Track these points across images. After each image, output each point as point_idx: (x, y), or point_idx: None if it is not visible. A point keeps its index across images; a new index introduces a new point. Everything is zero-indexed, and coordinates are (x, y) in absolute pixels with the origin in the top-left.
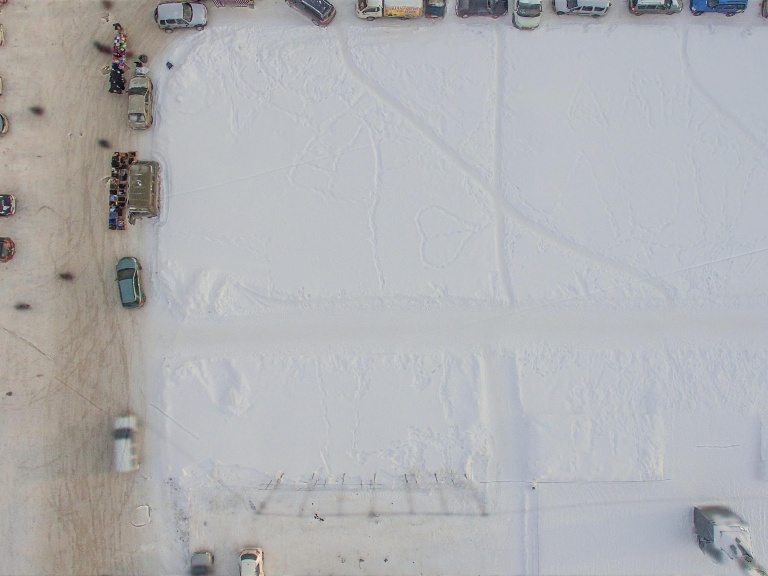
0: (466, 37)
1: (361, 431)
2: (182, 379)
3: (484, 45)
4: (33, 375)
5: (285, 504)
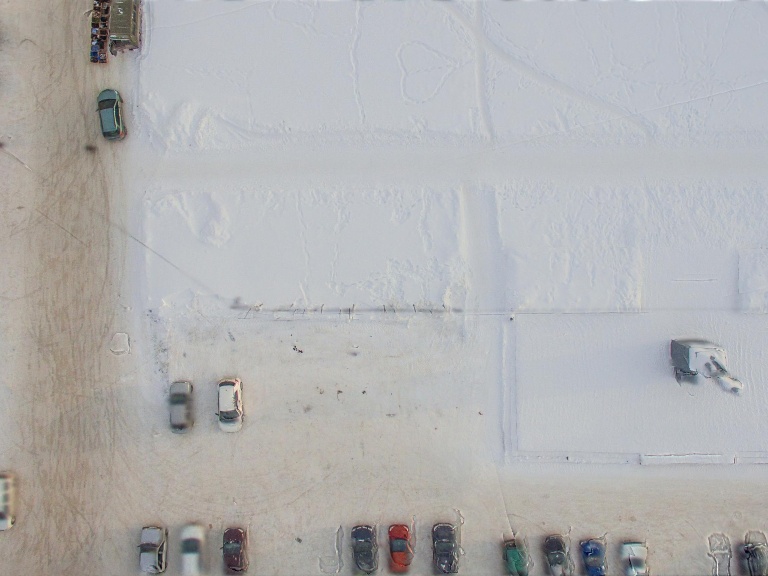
0: None
1: (340, 263)
2: (162, 211)
3: None
4: (14, 207)
5: (264, 335)
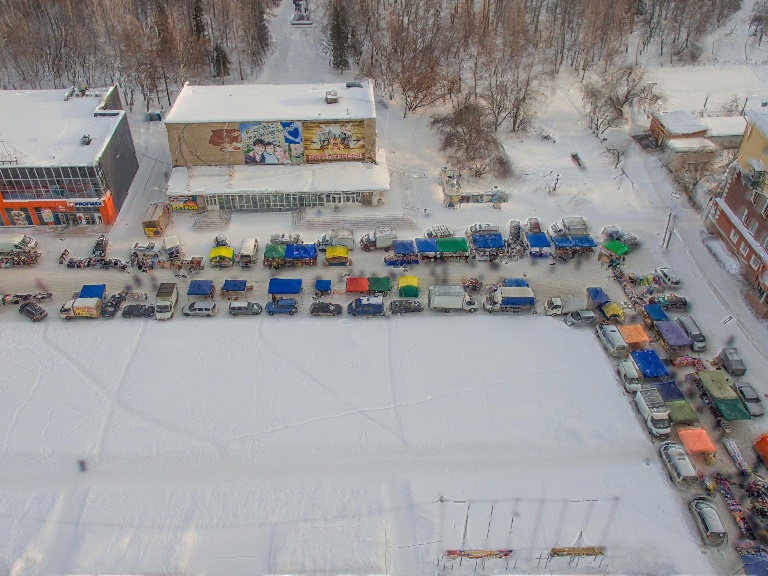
0: (123, 324)
1: None
2: None
3: (133, 327)
4: None
5: None
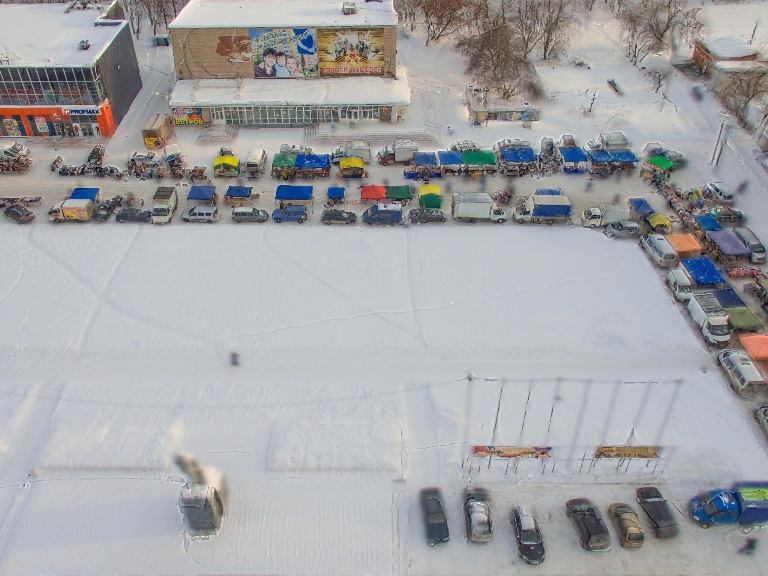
0: (116, 227)
1: None
2: None
3: (127, 230)
4: None
5: None
